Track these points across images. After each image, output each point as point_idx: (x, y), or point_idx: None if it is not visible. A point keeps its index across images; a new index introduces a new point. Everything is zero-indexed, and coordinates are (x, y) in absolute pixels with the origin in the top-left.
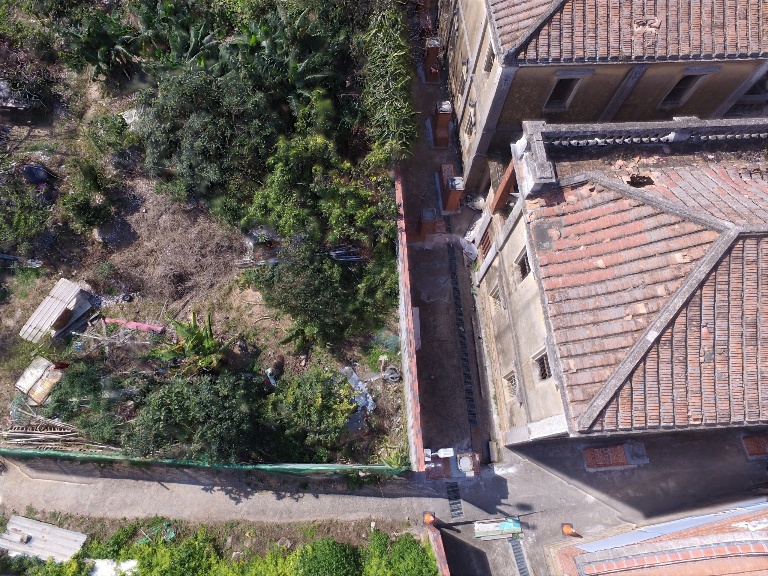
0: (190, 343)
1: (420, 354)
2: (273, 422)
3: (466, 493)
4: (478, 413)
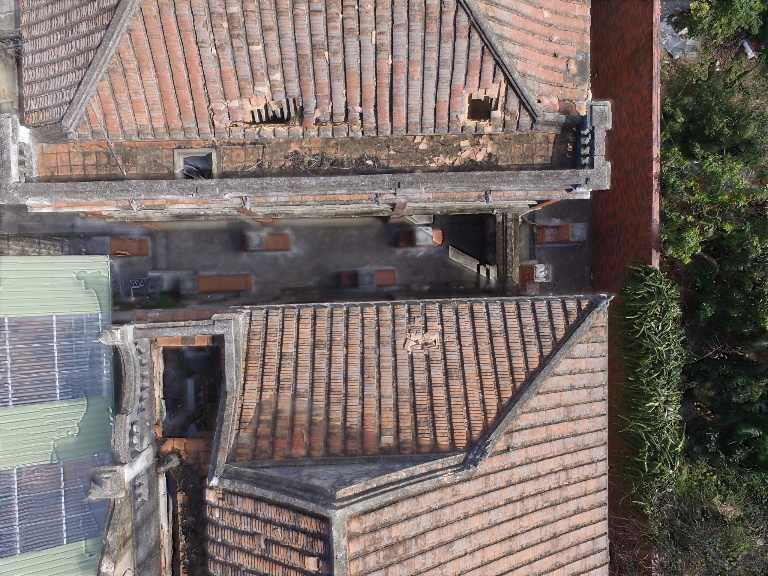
0: None
1: None
2: None
3: None
4: None
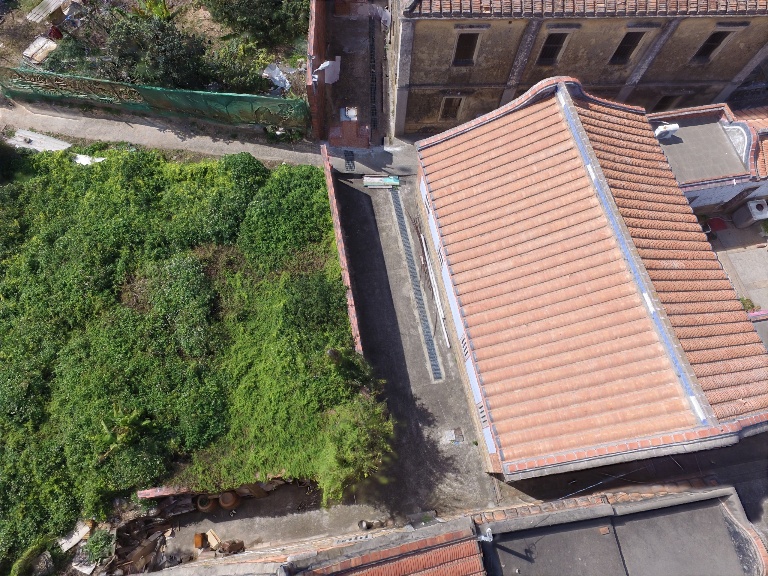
0: (148, 3)
1: (338, 84)
2: (208, 71)
3: (359, 158)
4: (379, 121)
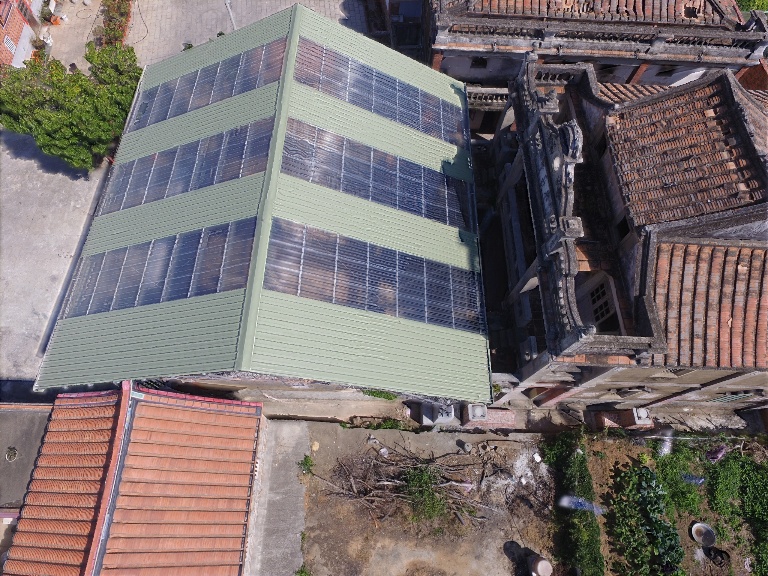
0: None
1: None
2: None
3: None
4: None
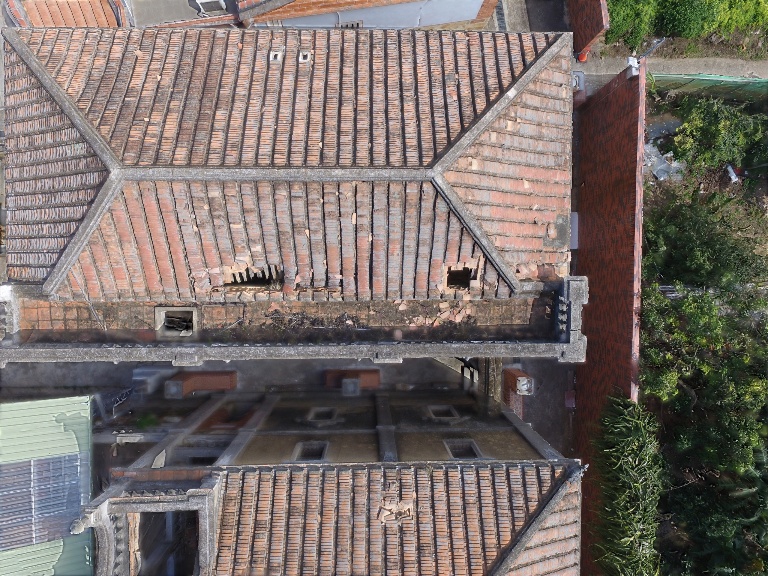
0: None
1: None
2: None
3: None
4: None
